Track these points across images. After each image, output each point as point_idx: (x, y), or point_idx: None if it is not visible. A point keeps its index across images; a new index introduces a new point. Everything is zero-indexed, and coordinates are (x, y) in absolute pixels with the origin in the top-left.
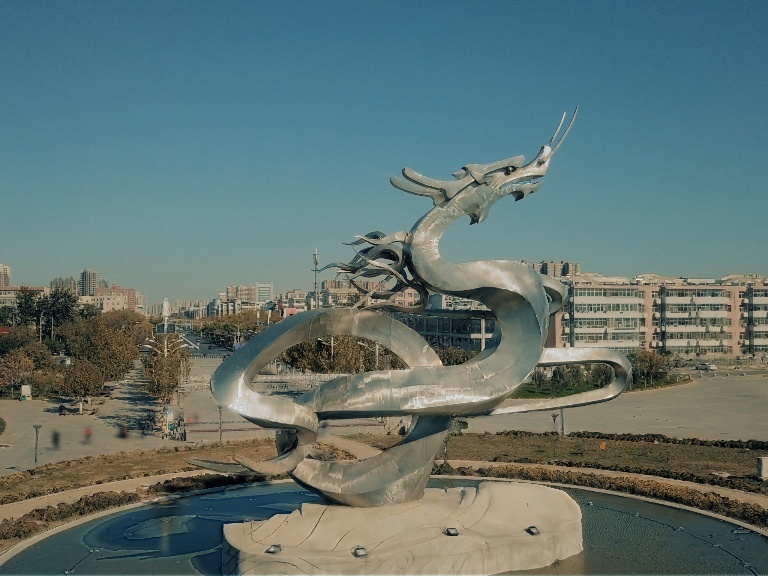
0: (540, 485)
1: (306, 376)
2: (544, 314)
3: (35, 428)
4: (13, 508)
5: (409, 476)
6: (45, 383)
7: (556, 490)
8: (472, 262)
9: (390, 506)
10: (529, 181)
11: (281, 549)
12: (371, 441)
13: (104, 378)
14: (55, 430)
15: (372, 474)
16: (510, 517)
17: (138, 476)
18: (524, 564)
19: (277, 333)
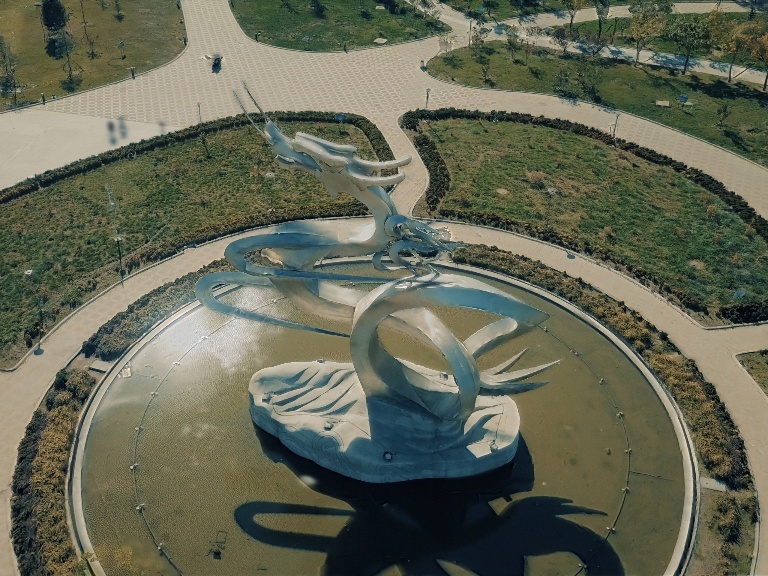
0: (284, 366)
1: None
2: None
3: None
4: None
5: None
6: None
7: None
8: None
9: None
10: None
11: None
12: None
13: None
14: None
15: None
16: None
17: None
18: None
19: None
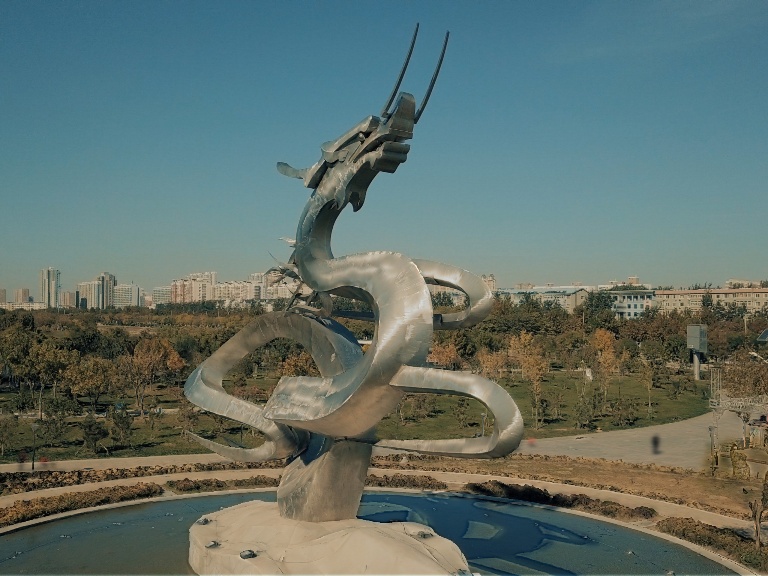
0: (411, 553)
1: None
2: (403, 320)
3: None
4: None
5: None
6: None
7: (428, 568)
8: None
9: (282, 518)
10: None
11: (208, 524)
12: None
13: None
14: (673, 435)
15: None
16: (337, 572)
17: (515, 476)
18: None
19: None
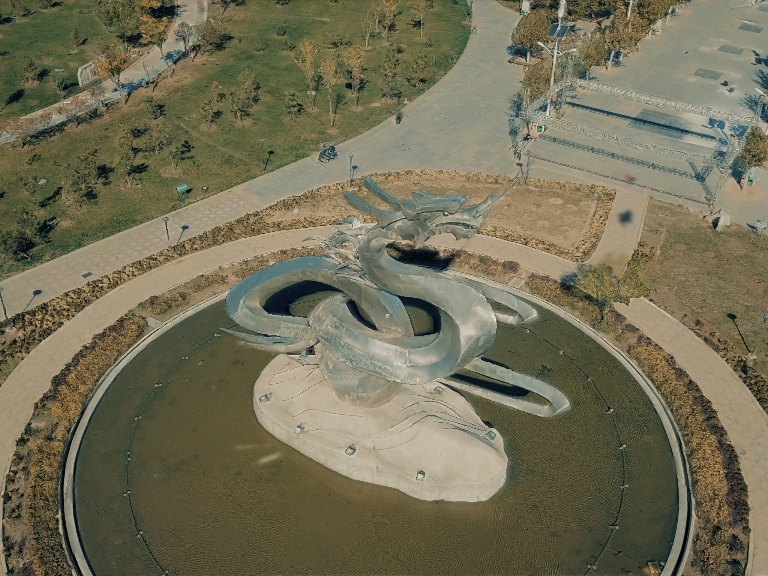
0: (469, 442)
1: (692, 107)
2: (477, 334)
3: (350, 156)
4: (283, 237)
5: (360, 394)
6: (545, 0)
7: (483, 451)
8: (413, 275)
9: (347, 405)
10: (467, 226)
11: (270, 400)
12: (664, 226)
13: (576, 18)
14: (464, 98)
15: (345, 378)
16: (419, 455)
17: None
18: (407, 491)
19: (274, 274)
